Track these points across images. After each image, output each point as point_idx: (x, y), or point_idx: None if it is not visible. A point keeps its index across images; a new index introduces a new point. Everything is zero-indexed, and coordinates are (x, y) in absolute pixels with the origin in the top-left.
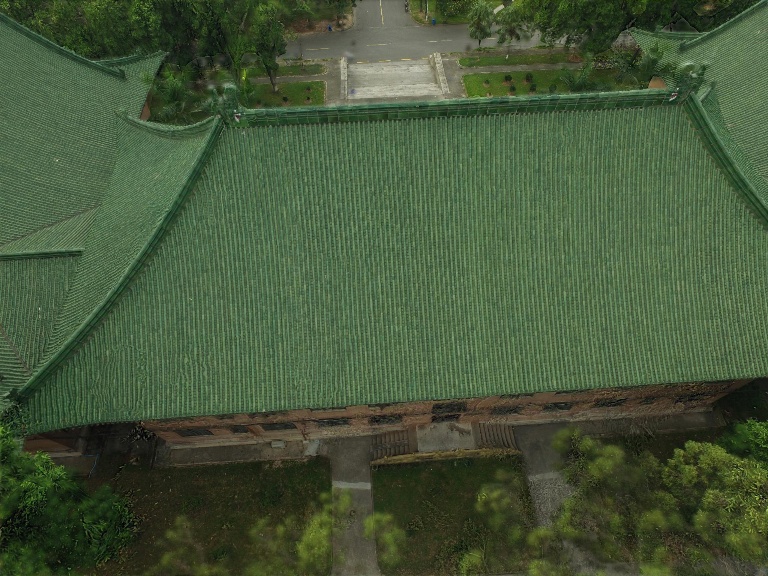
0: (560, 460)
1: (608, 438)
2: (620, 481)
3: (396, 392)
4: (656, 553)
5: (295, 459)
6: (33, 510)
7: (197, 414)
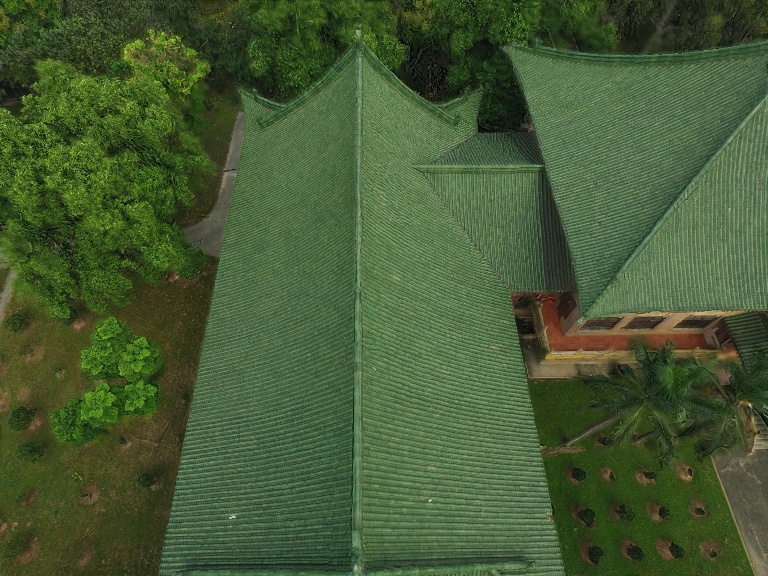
0: None
1: None
2: None
3: None
4: None
5: None
6: None
7: None
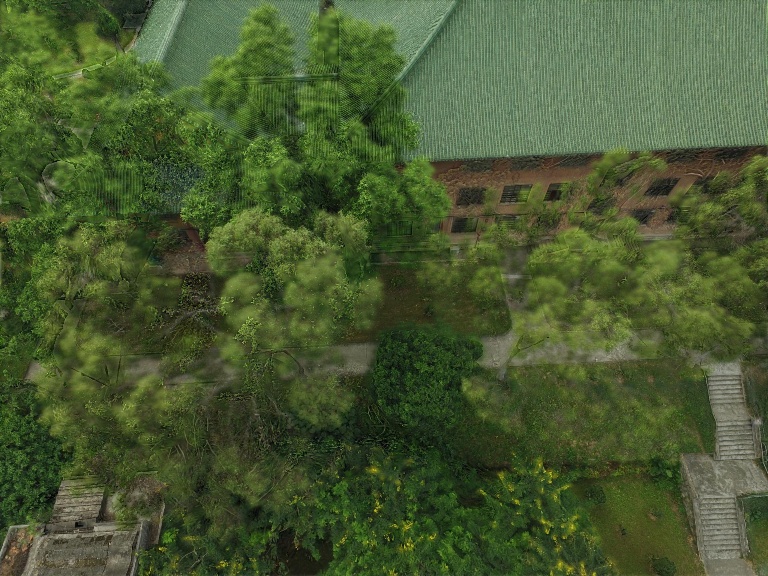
0: (678, 263)
1: (714, 250)
2: (729, 273)
3: (600, 146)
4: (761, 318)
5: (468, 261)
6: (274, 288)
7: (461, 157)
